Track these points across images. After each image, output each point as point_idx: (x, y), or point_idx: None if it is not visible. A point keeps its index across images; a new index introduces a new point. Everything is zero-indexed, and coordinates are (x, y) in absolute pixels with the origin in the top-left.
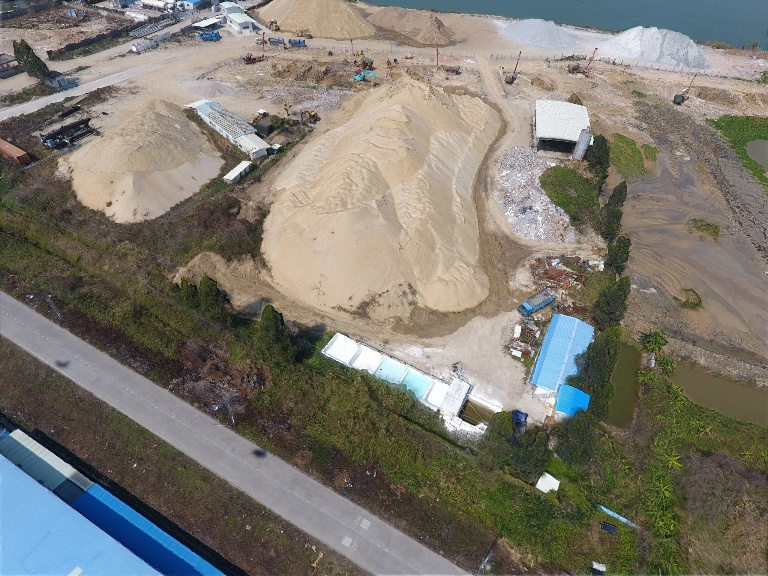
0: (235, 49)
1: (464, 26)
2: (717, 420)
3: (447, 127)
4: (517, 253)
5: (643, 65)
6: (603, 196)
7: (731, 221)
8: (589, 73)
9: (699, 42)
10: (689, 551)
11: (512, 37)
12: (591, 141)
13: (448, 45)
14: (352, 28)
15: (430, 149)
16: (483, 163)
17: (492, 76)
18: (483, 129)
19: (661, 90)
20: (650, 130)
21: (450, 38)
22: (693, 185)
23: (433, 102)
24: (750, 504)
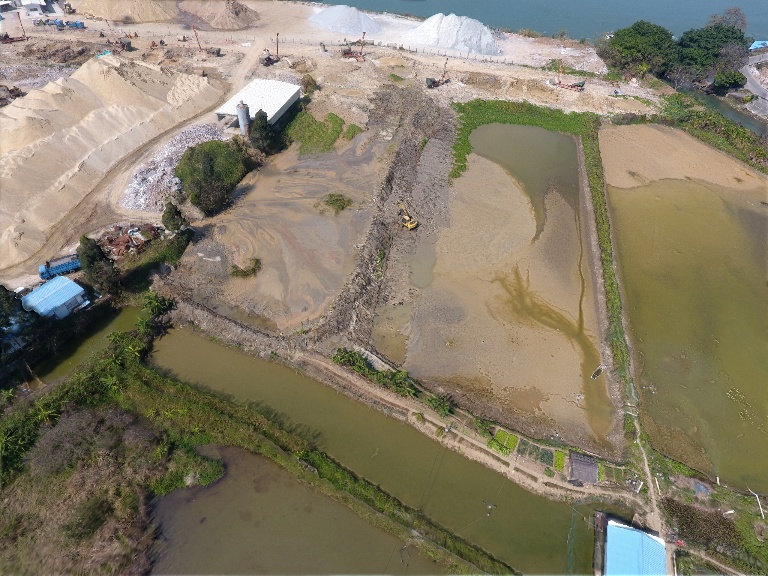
0: (7, 30)
1: (277, 12)
2: (143, 379)
3: (124, 102)
4: (103, 221)
5: (431, 51)
6: (257, 171)
7: (373, 197)
8: (360, 57)
9: (512, 31)
10: (3, 501)
11: (318, 23)
12: (267, 117)
13: (240, 29)
14: (144, 12)
15: (80, 121)
16: (156, 138)
17: (255, 58)
18: (178, 106)
19: (427, 75)
20: (375, 111)
21: (250, 23)
22: (367, 163)
23: (112, 77)
24: (104, 458)
